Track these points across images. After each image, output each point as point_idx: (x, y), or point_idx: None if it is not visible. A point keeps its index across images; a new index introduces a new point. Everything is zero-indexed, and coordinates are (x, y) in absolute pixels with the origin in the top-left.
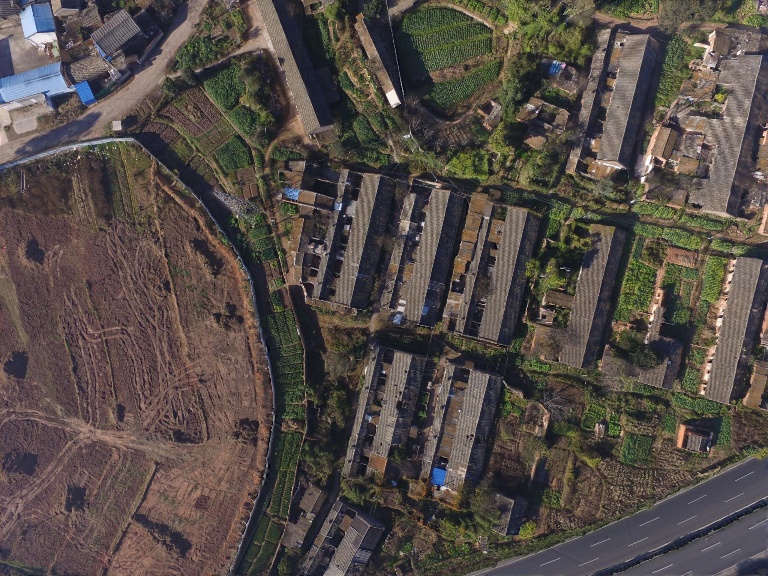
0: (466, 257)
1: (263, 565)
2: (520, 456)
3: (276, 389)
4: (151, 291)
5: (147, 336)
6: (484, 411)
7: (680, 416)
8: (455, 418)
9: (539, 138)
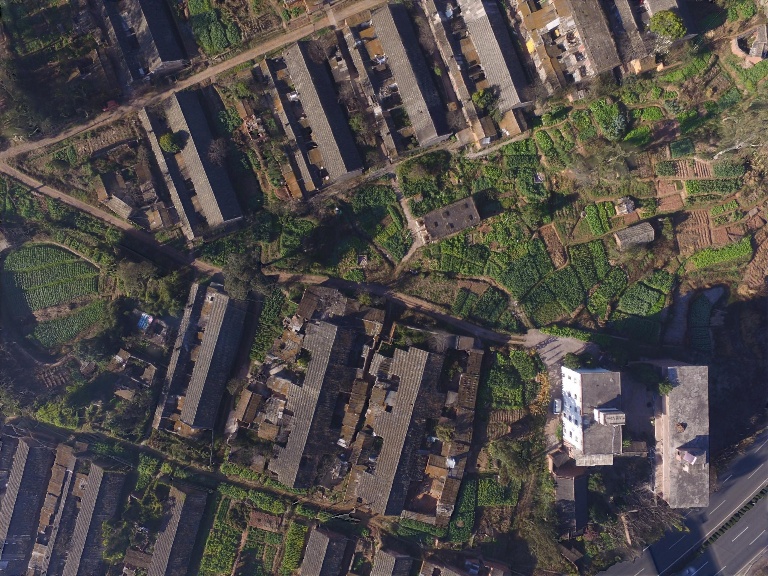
0: (49, 510)
1: None
2: None
3: None
4: None
5: None
6: None
7: None
8: None
9: (127, 391)
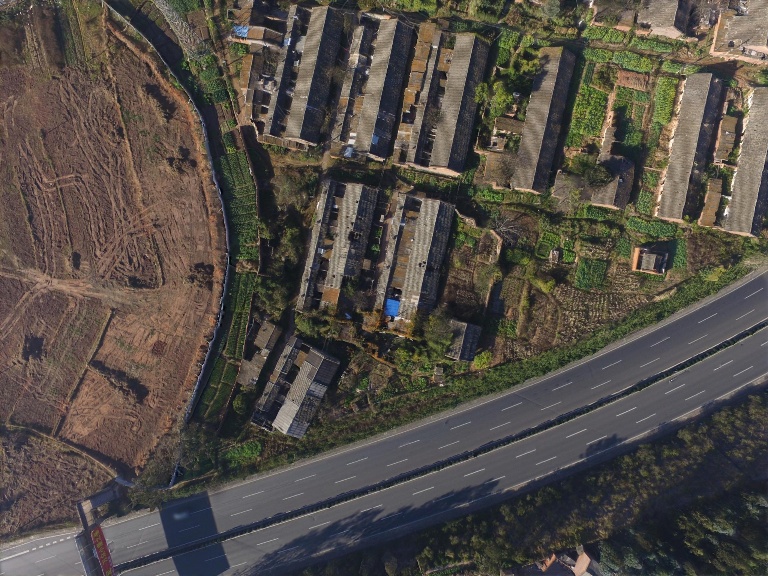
0: (415, 87)
1: (220, 407)
2: (475, 287)
3: (230, 230)
4: (105, 138)
5: (101, 183)
6: (436, 238)
7: (635, 241)
8: (408, 248)
9: None
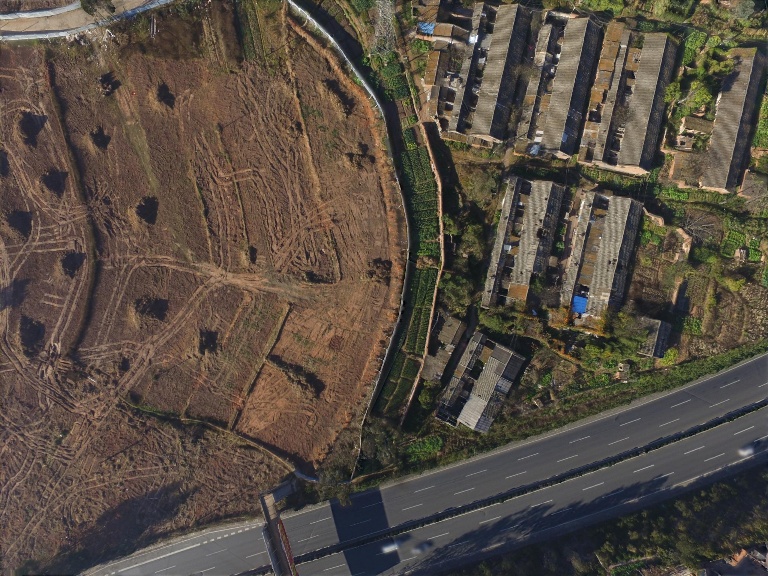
0: (604, 86)
1: (399, 402)
2: (659, 285)
3: (410, 226)
4: (282, 133)
5: (279, 177)
6: (626, 236)
7: None
8: (595, 246)
9: None
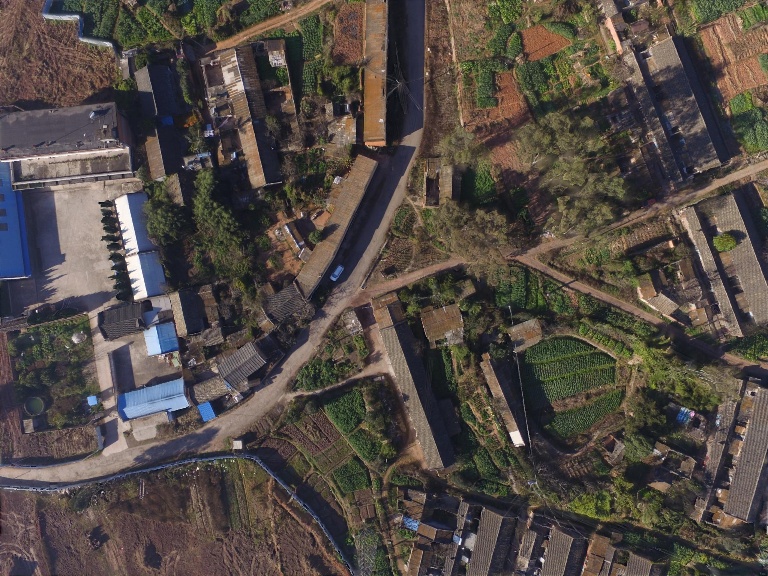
0: None
1: None
2: None
3: None
4: None
5: None
6: None
7: None
8: None
9: (664, 483)
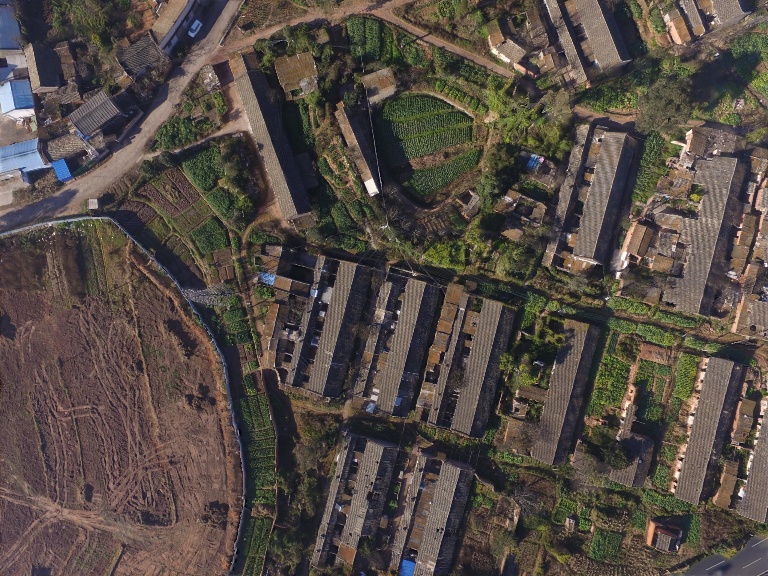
0: (441, 348)
1: None
2: (490, 549)
3: (247, 473)
4: (123, 370)
5: (118, 416)
6: (455, 504)
7: (650, 512)
8: (426, 510)
9: (516, 231)
